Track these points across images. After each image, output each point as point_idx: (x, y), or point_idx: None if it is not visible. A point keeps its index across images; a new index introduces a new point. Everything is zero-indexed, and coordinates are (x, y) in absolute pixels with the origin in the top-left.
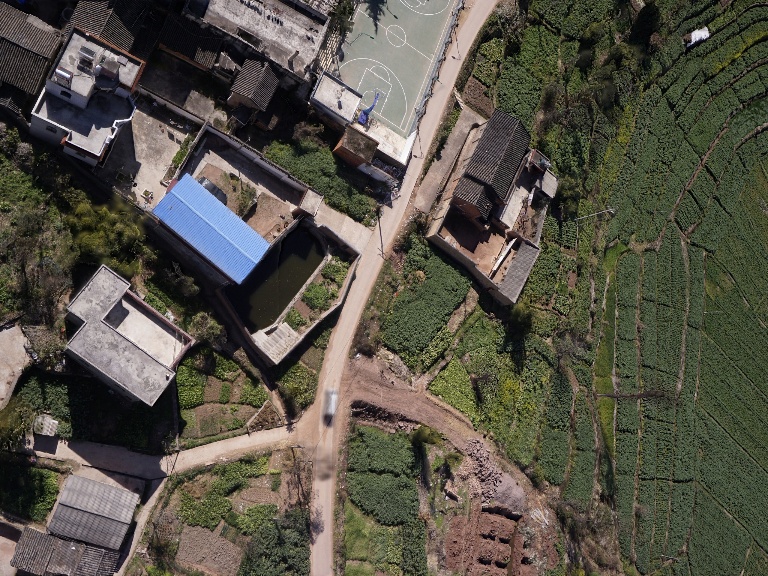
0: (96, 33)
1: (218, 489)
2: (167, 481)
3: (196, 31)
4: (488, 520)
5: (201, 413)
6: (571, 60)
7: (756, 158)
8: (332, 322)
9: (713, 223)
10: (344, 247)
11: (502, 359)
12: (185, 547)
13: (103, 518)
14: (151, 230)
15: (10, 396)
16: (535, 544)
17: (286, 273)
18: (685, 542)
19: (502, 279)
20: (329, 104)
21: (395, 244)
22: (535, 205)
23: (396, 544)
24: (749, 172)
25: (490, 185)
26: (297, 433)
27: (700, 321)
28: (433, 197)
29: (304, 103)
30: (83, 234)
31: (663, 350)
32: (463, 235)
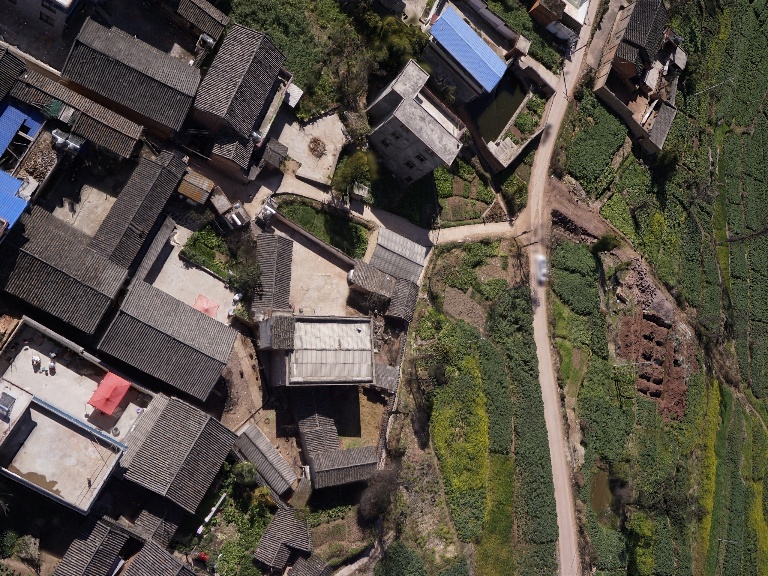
0: None
1: (467, 261)
2: (434, 249)
3: None
4: (648, 324)
5: (452, 203)
6: None
7: None
8: (535, 146)
9: None
10: (542, 87)
11: (650, 198)
12: (448, 302)
13: (406, 260)
14: None
15: None
16: (682, 350)
17: (501, 104)
18: None
19: (648, 132)
20: None
21: (575, 90)
22: (667, 77)
23: (587, 329)
24: None
25: (644, 48)
26: (516, 228)
27: None
28: (599, 57)
29: None
30: (391, 39)
31: (761, 217)
32: (619, 93)
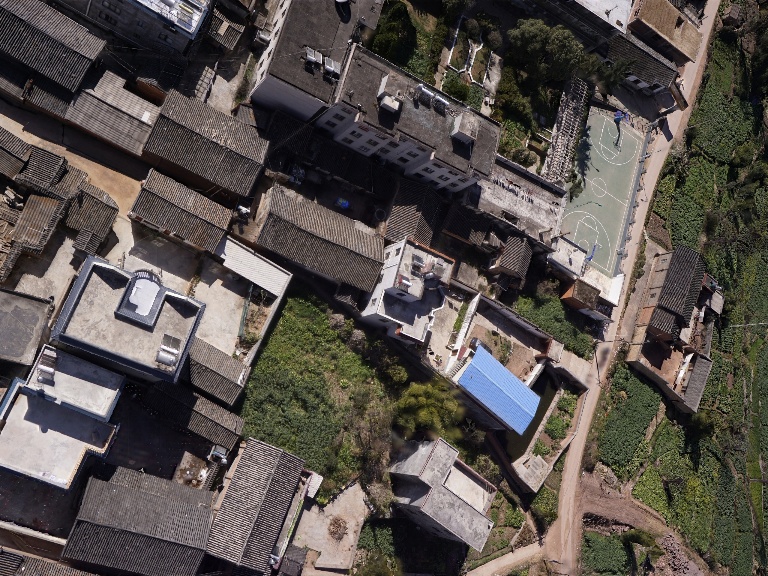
0: (410, 235)
1: None
2: None
3: (471, 216)
4: None
5: None
6: (726, 186)
7: None
8: (566, 447)
9: None
10: (574, 382)
11: (683, 459)
12: None
13: None
14: None
15: (357, 543)
16: None
17: None
18: None
19: (682, 390)
20: (563, 262)
21: (608, 373)
22: None
23: None
24: None
25: (681, 315)
26: (546, 546)
27: None
28: (633, 327)
29: (543, 262)
30: (418, 410)
31: None
32: (653, 355)
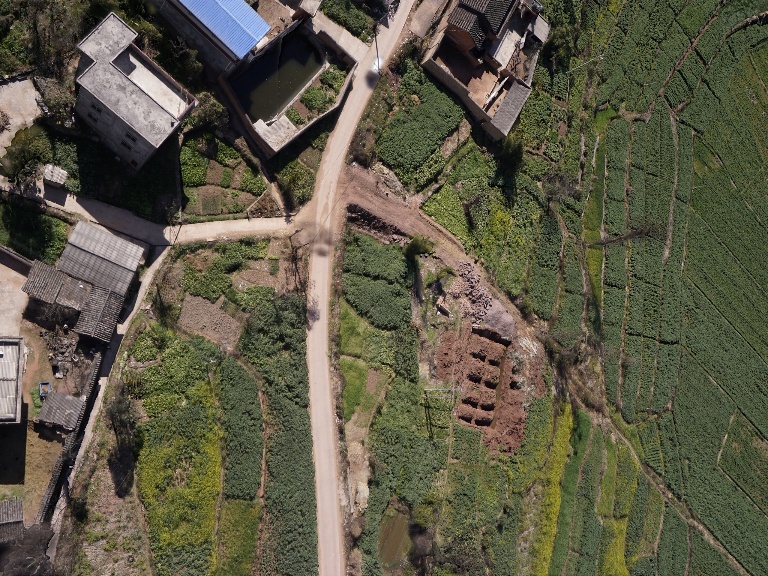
0: None
1: (219, 265)
2: (170, 249)
3: None
4: (478, 340)
5: (203, 193)
6: None
7: (745, 48)
8: (329, 127)
9: (702, 104)
10: (342, 56)
11: (493, 192)
12: (187, 314)
13: (110, 263)
14: (157, 12)
15: None
16: (524, 370)
17: (286, 75)
18: (670, 400)
19: (494, 115)
20: None
21: (391, 62)
22: (527, 51)
23: (389, 346)
24: (738, 61)
25: (483, 14)
26: (295, 225)
27: (688, 194)
28: (428, 24)
29: None
30: None
31: (651, 216)
32: (457, 67)
